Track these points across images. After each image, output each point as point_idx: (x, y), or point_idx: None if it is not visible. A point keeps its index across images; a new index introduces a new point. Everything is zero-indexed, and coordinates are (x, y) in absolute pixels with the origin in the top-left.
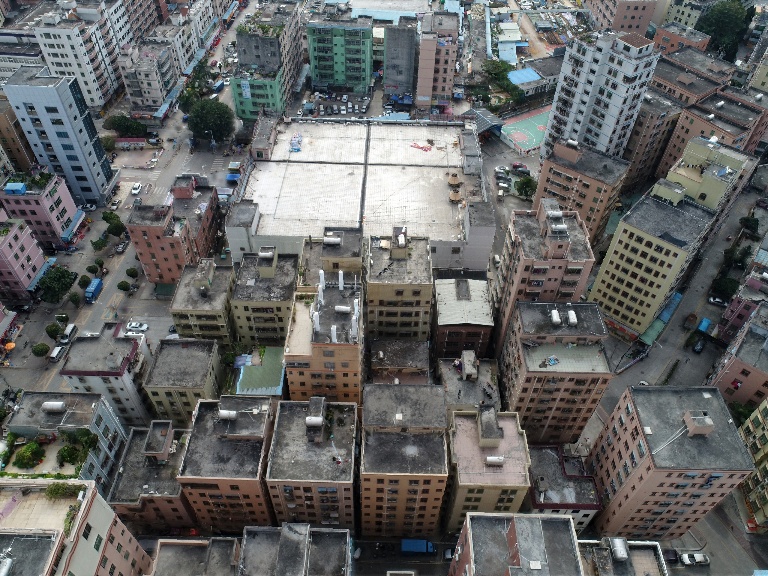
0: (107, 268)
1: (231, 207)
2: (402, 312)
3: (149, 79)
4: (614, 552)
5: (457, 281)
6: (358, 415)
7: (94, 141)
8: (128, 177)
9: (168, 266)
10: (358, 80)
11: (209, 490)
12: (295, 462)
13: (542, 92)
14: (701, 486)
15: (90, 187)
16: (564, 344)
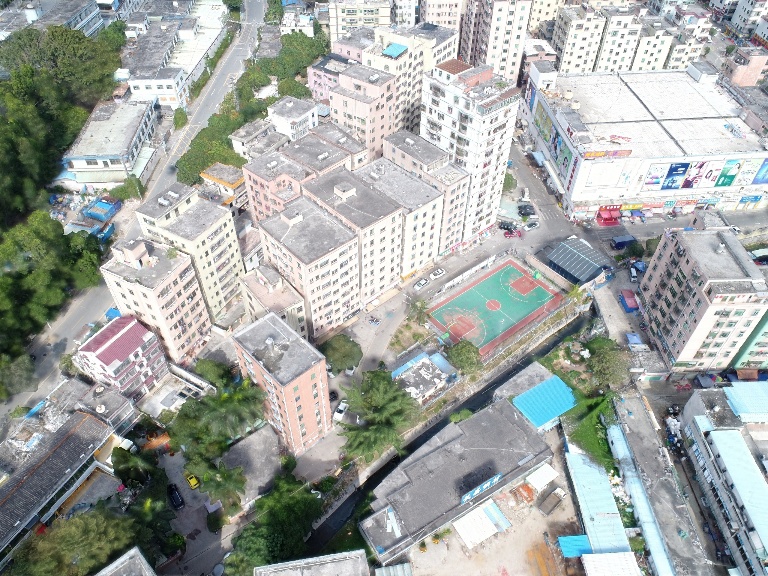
0: None
1: None
2: None
3: None
4: None
5: None
6: None
7: None
8: None
9: None
10: None
11: None
12: None
13: None
14: None
15: None
16: None
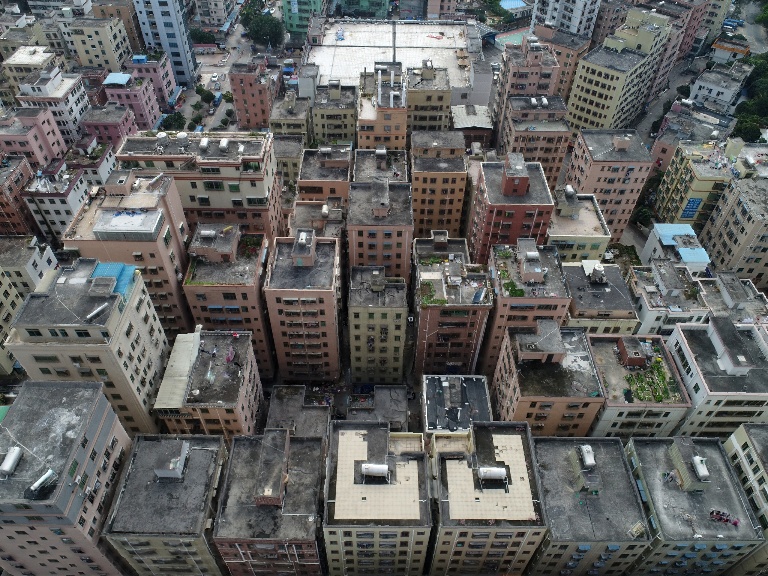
0: (204, 123)
1: (300, 67)
2: (430, 116)
3: (216, 0)
4: (566, 190)
5: (466, 105)
6: (407, 155)
7: (187, 35)
8: (206, 71)
9: (255, 111)
10: (379, 6)
11: (316, 194)
12: (370, 177)
13: (528, 16)
14: (624, 182)
15: (184, 71)
16: (540, 121)
